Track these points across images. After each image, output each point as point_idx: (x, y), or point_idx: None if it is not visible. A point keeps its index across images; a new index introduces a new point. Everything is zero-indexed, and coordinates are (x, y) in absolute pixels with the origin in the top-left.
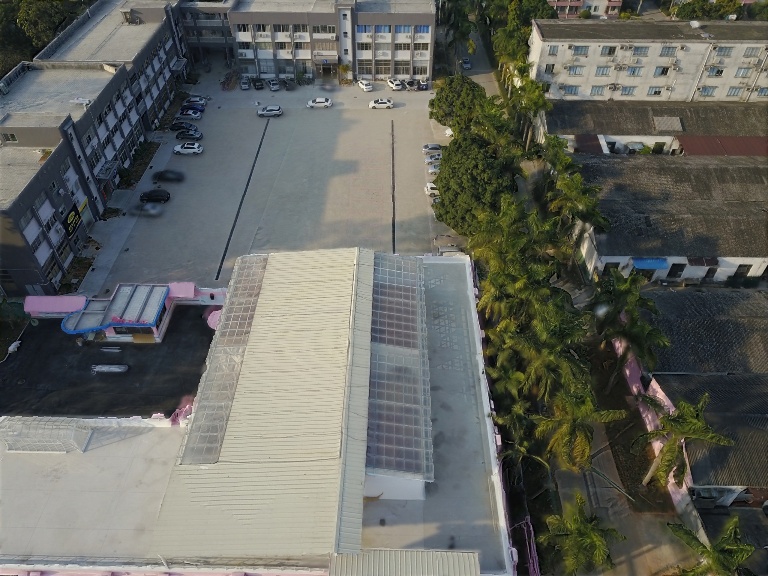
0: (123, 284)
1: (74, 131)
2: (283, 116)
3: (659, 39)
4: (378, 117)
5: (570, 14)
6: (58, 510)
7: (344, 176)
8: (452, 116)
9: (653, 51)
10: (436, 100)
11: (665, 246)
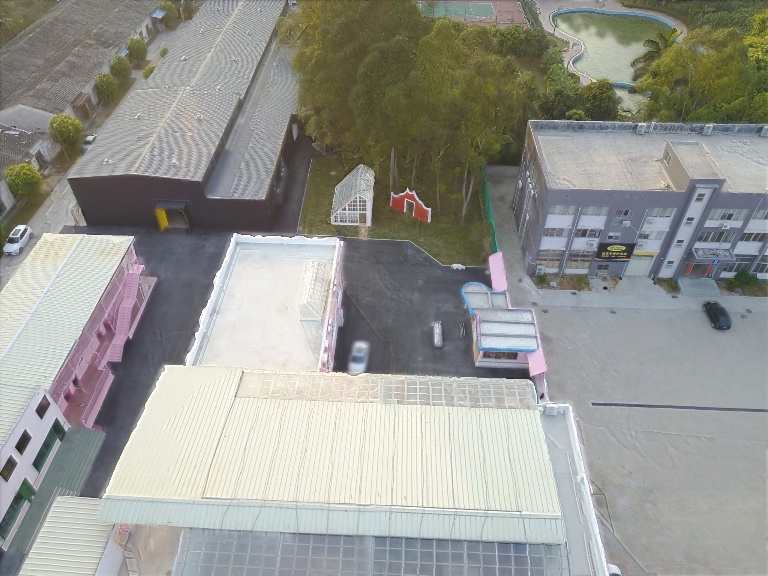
0: (533, 312)
1: (711, 196)
2: None
3: None
4: None
5: None
6: (251, 318)
7: None
8: None
9: None
10: None
11: None
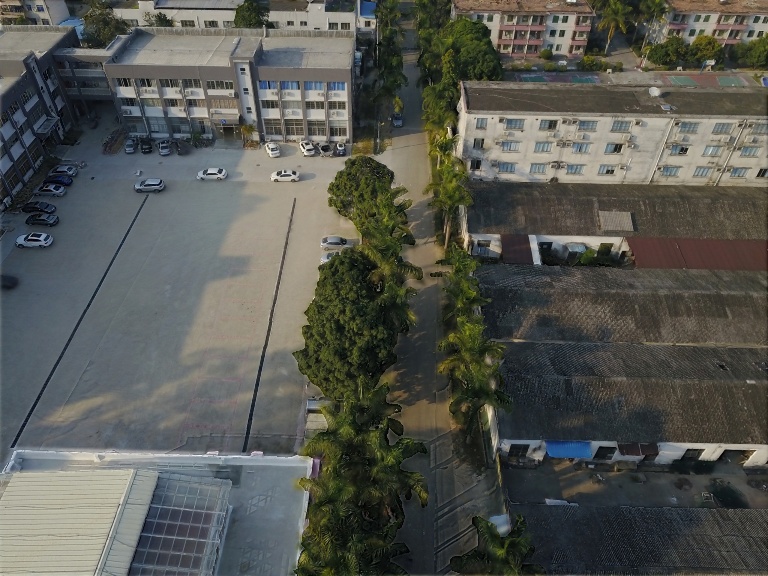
0: None
1: None
2: (165, 191)
3: (609, 112)
4: (279, 193)
5: (529, 53)
6: None
7: (217, 282)
8: (352, 207)
9: (602, 126)
10: (334, 186)
11: (588, 425)
